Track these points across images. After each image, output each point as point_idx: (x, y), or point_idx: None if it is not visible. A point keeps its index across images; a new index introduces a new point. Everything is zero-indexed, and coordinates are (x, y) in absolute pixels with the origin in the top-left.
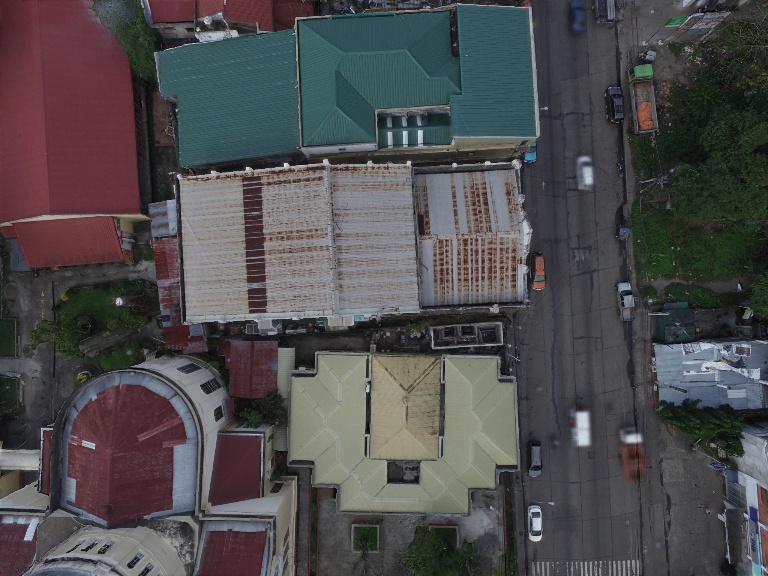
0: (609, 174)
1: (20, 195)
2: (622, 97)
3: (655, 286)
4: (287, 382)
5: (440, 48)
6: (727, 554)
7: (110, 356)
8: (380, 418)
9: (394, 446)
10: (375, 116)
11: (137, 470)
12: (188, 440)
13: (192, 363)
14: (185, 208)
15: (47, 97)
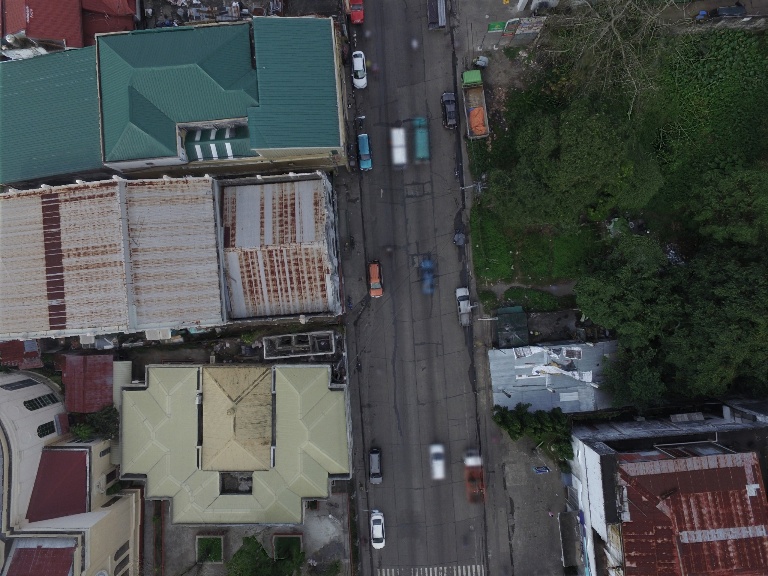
0: (447, 180)
1: None
2: (455, 103)
3: (495, 291)
4: None
5: (238, 61)
6: (562, 557)
7: None
8: (211, 430)
9: (225, 457)
10: (176, 130)
11: None
12: None
13: (29, 379)
14: None
15: None
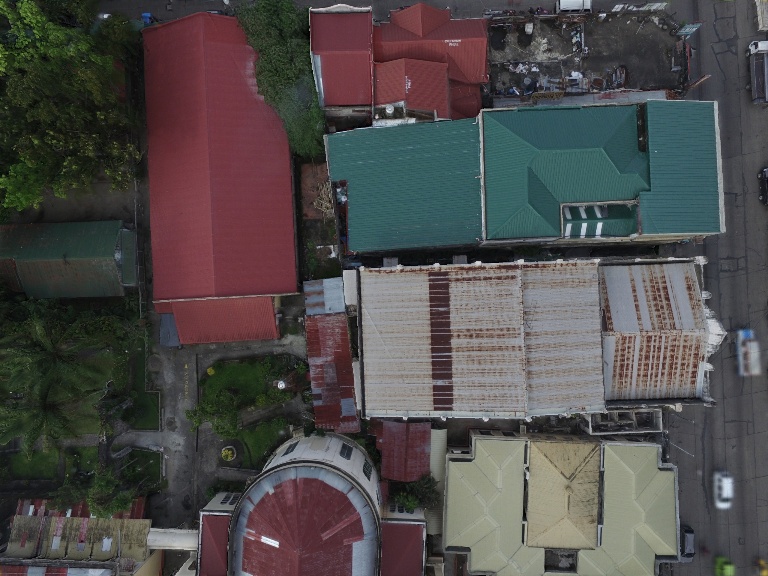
0: (762, 256)
1: (180, 273)
2: None
3: None
4: (440, 464)
5: (628, 143)
6: None
7: (254, 431)
8: (539, 505)
9: (553, 534)
10: (561, 210)
11: (321, 570)
12: (365, 536)
13: (343, 443)
14: (366, 300)
15: (213, 177)
